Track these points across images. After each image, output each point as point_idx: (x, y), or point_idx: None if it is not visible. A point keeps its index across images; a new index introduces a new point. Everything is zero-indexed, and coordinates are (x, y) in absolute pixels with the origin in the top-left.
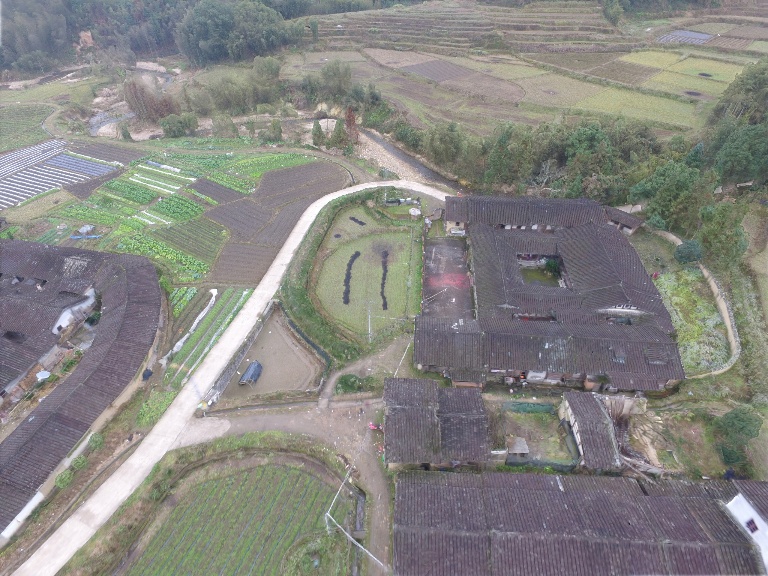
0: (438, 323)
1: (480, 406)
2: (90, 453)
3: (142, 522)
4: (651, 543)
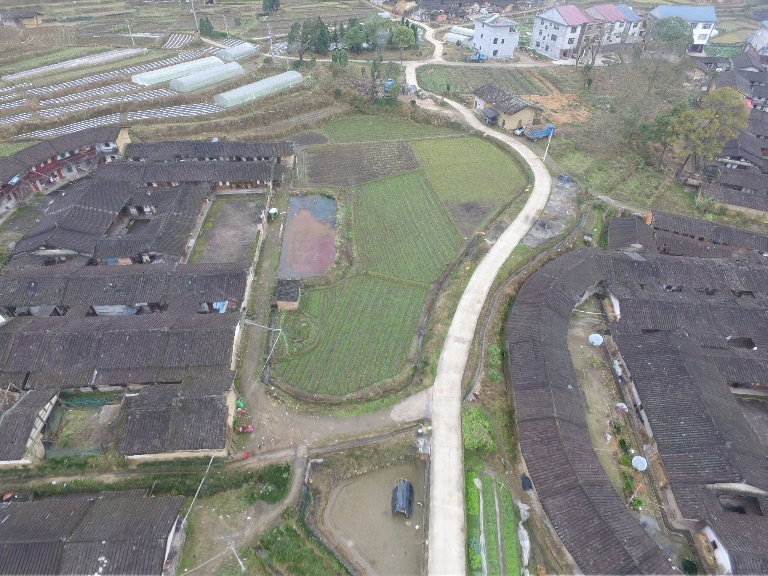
0: (125, 573)
1: (129, 424)
2: (506, 390)
3: (424, 348)
4: (60, 332)
